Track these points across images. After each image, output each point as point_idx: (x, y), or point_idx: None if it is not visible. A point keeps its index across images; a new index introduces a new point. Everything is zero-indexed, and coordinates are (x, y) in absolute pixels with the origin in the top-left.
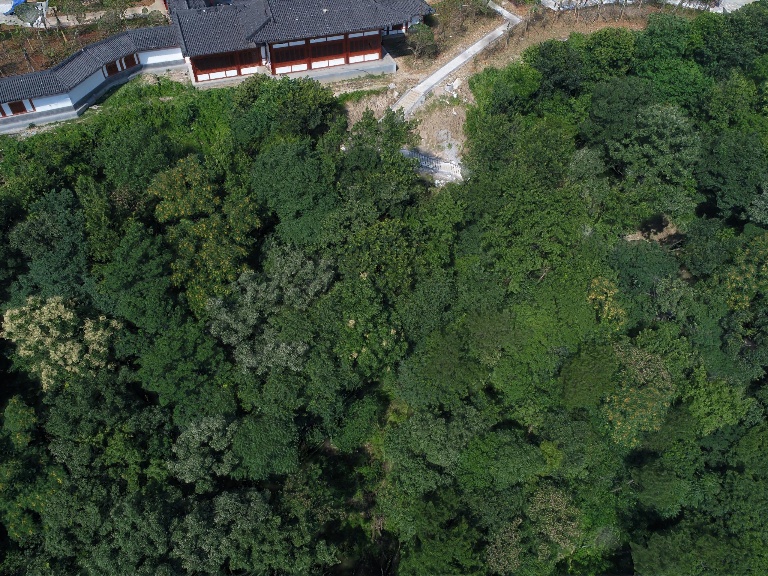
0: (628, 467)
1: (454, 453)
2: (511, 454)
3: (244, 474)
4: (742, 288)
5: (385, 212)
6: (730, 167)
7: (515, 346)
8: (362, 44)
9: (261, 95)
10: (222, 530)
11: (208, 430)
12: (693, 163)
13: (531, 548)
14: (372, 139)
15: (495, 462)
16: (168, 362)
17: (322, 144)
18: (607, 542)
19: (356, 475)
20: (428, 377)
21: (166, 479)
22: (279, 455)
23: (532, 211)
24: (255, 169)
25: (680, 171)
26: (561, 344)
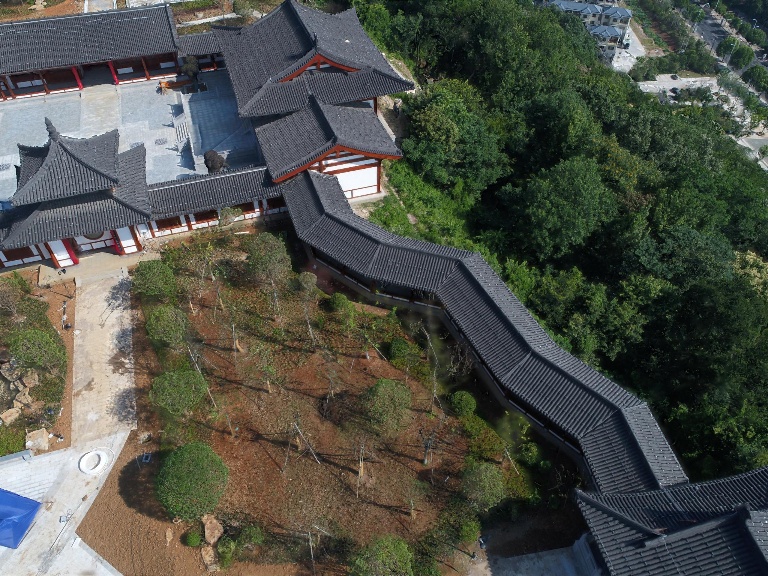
0: None
1: None
2: None
3: None
4: None
5: None
6: None
7: None
8: None
9: None
10: None
11: None
12: None
13: None
14: None
15: None
16: None
17: None
18: None
19: None
20: None
21: None
22: None
23: None
24: None
25: None
26: None
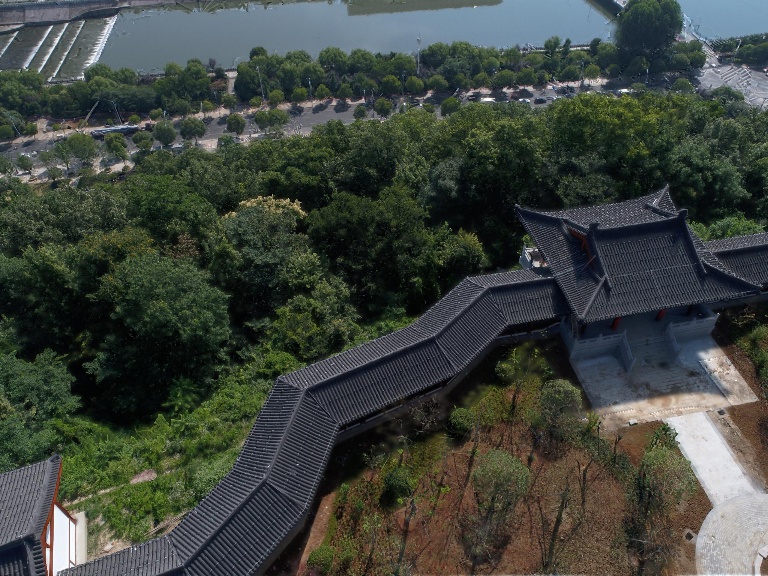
0: None
1: None
2: None
3: None
4: None
5: None
6: None
7: None
8: None
9: None
10: None
11: None
12: None
13: None
14: None
15: None
16: None
17: None
18: None
19: None
20: None
21: None
22: None
23: None
24: None
25: None
26: None
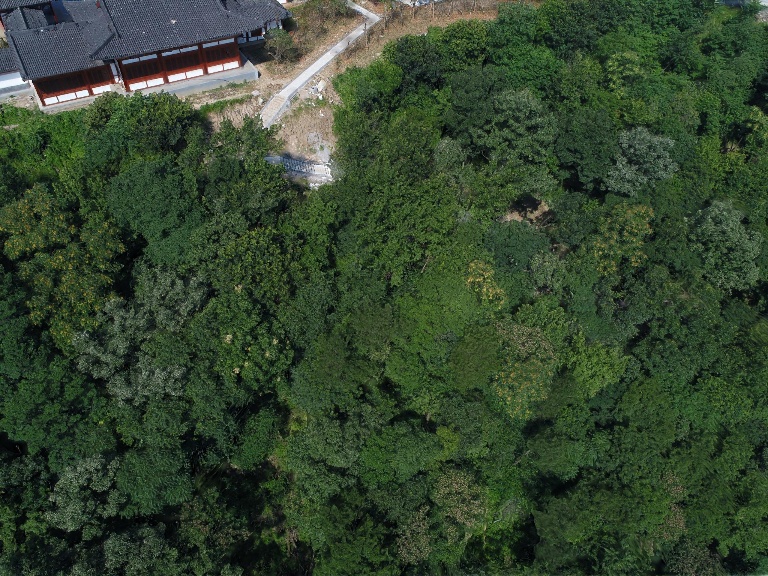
0: (526, 438)
1: (352, 453)
2: (408, 445)
3: (135, 511)
4: (609, 254)
5: (256, 221)
6: (585, 143)
7: (403, 338)
8: (219, 53)
9: (114, 114)
10: (115, 574)
11: (86, 472)
12: (552, 142)
13: (441, 533)
14: (232, 149)
15: (393, 455)
16: (31, 407)
17: (181, 159)
18: (512, 514)
19: (262, 491)
20: (320, 381)
21: (47, 531)
22: (169, 485)
23: (402, 204)
24: (111, 192)
25: (539, 151)
26: (448, 330)
